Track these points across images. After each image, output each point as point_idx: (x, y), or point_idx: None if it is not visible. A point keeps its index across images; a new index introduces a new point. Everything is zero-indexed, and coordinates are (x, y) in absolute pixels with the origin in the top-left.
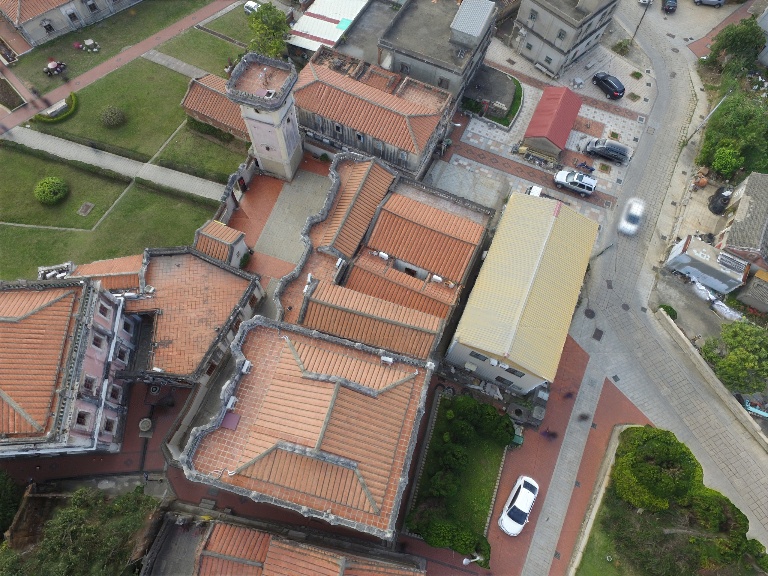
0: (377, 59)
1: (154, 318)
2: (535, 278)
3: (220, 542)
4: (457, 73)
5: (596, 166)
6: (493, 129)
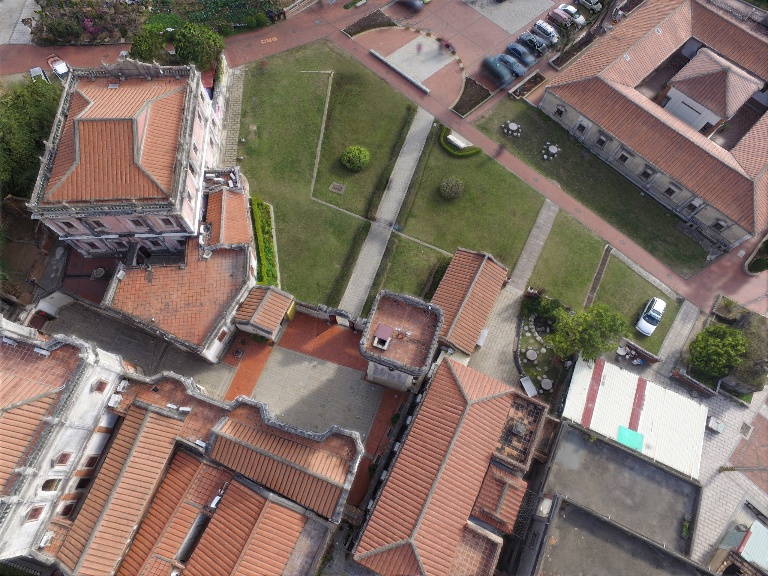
0: (562, 493)
1: (178, 263)
2: None
3: None
4: None
5: None
6: None
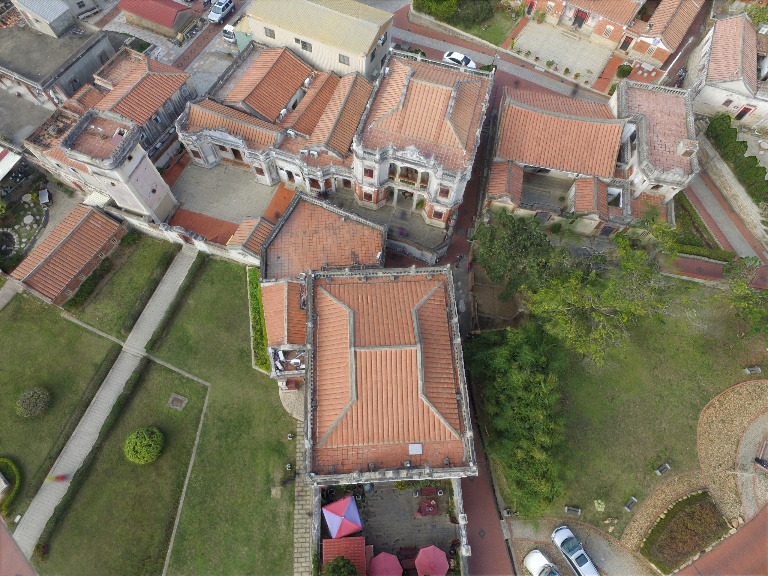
0: None
1: None
2: (324, 6)
3: (500, 188)
4: (103, 37)
5: (205, 0)
6: (150, 55)
